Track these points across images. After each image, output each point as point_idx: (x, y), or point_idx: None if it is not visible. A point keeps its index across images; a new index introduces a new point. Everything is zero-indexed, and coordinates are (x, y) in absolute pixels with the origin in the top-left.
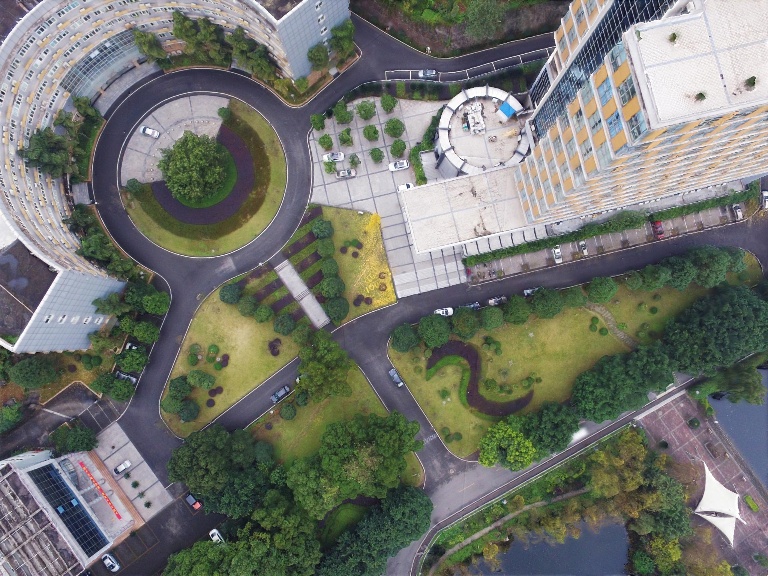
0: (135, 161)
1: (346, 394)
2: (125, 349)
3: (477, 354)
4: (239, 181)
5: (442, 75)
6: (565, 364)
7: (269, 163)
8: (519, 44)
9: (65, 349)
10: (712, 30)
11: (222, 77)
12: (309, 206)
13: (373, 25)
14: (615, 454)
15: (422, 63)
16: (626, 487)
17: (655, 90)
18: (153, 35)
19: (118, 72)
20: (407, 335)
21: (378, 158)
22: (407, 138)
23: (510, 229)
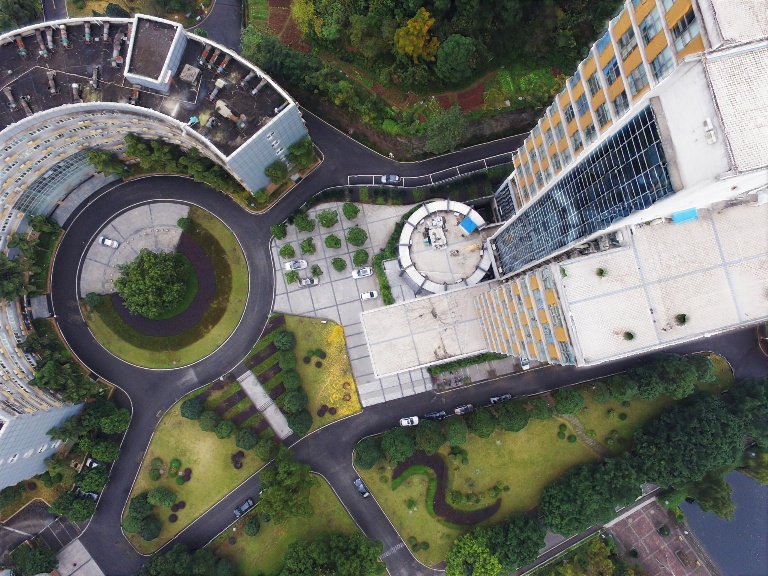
0: (94, 272)
1: (307, 516)
2: (86, 465)
3: (443, 463)
4: (200, 291)
5: (405, 180)
6: (533, 472)
7: (231, 272)
8: (483, 148)
9: (19, 481)
10: (641, 262)
11: (182, 183)
12: (271, 315)
13: (335, 128)
14: (583, 569)
15: (385, 168)
16: None
17: (582, 327)
18: (108, 153)
19: (75, 184)
20: (369, 454)
21: (340, 268)
22: (371, 244)
23: (471, 351)
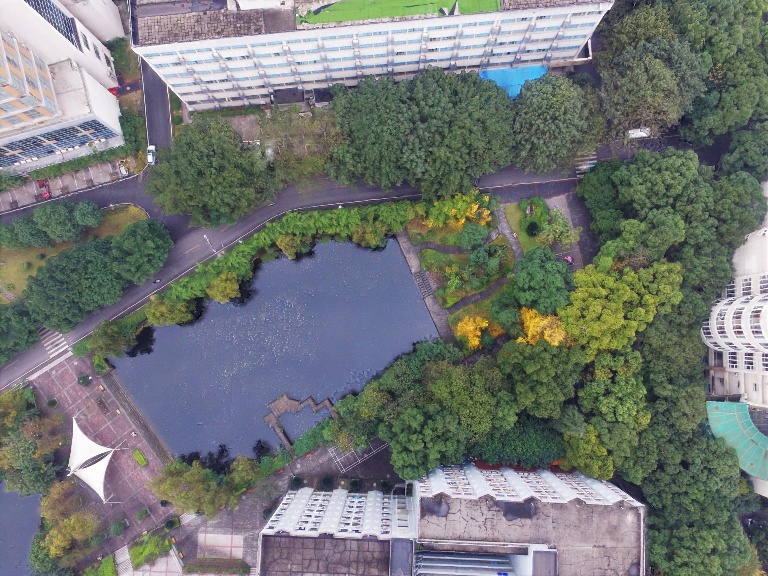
0: None
1: None
2: None
3: None
4: None
5: None
6: None
7: None
8: None
9: None
10: None
11: None
12: None
13: None
14: None
15: None
16: None
17: None
18: None
19: None
20: None
21: None
22: None
23: None
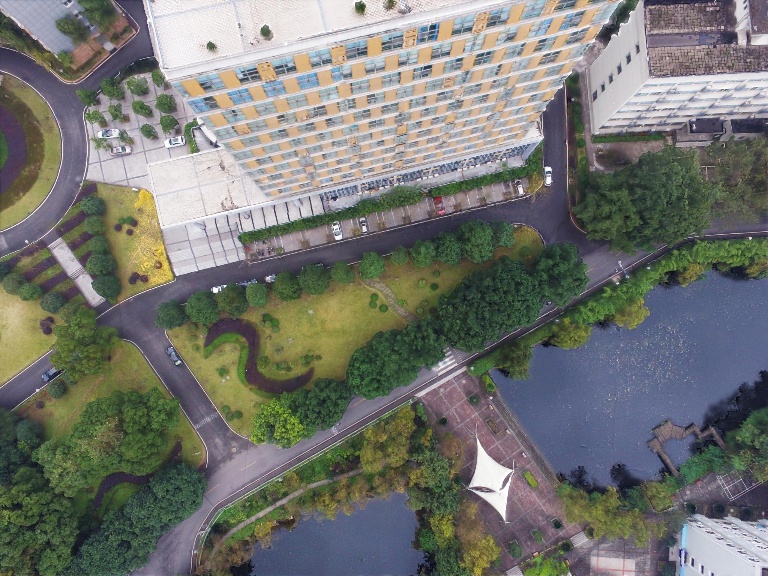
0: None
1: (102, 371)
2: None
3: (255, 332)
4: (11, 158)
5: None
6: (346, 341)
7: (43, 140)
8: None
9: None
10: None
11: None
12: (83, 183)
13: None
14: None
15: None
16: (390, 463)
17: (168, 39)
18: None
19: None
20: (165, 311)
21: (148, 134)
22: (185, 114)
23: (258, 203)
